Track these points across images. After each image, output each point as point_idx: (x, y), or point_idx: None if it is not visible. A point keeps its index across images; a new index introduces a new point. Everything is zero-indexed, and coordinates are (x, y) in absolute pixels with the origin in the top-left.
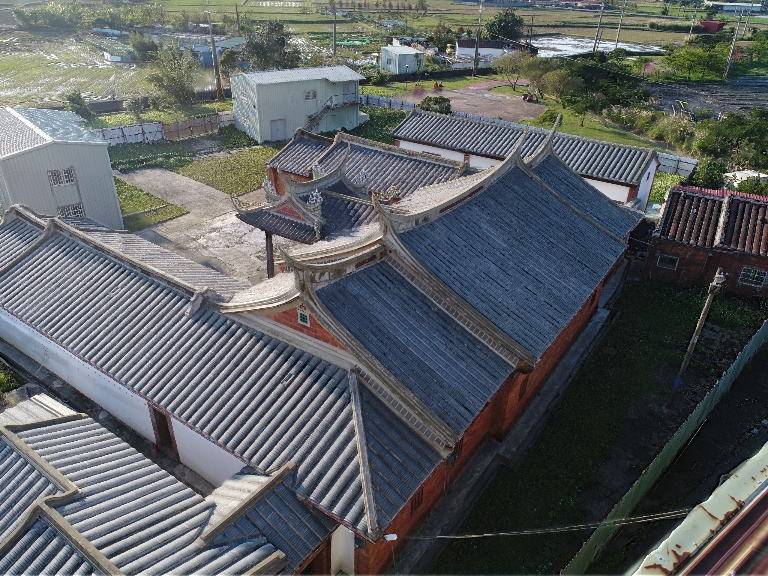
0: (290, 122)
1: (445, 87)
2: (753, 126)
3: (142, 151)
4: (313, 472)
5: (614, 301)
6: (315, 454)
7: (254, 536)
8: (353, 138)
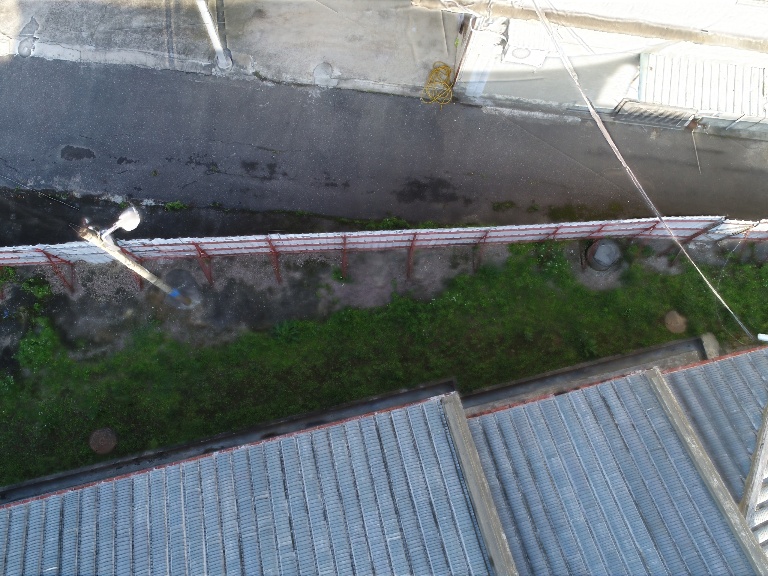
0: None
1: None
2: None
3: None
4: None
5: None
6: None
7: None
8: None
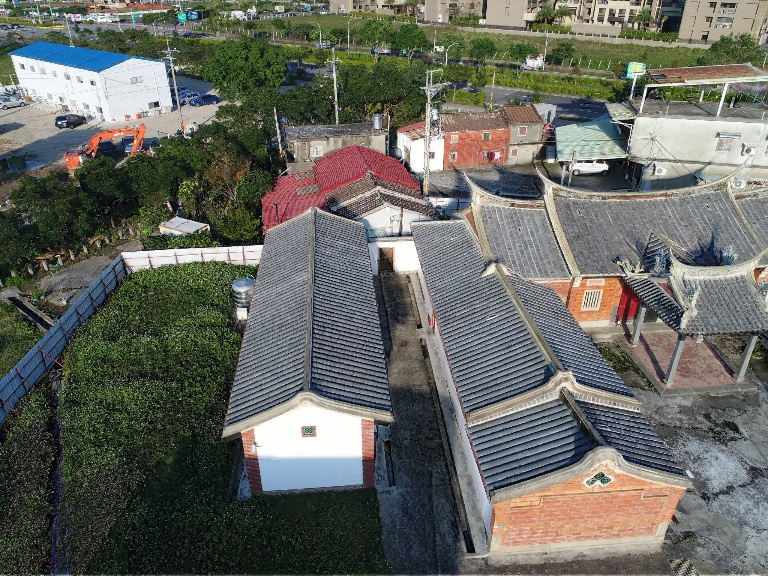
0: None
1: None
2: (69, 204)
3: None
4: None
5: None
6: None
7: None
8: None
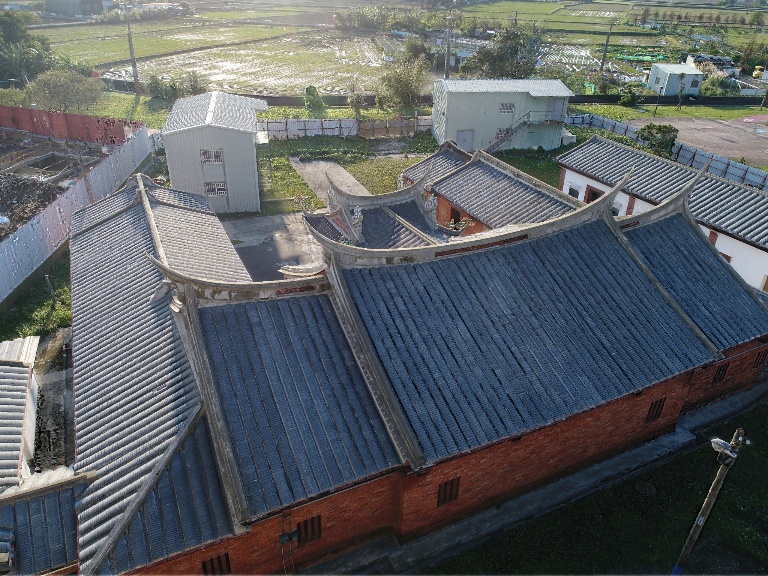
0: (479, 134)
1: (711, 115)
2: None
3: (332, 144)
4: (99, 491)
5: (713, 426)
6: (115, 473)
7: (6, 529)
8: (489, 158)
